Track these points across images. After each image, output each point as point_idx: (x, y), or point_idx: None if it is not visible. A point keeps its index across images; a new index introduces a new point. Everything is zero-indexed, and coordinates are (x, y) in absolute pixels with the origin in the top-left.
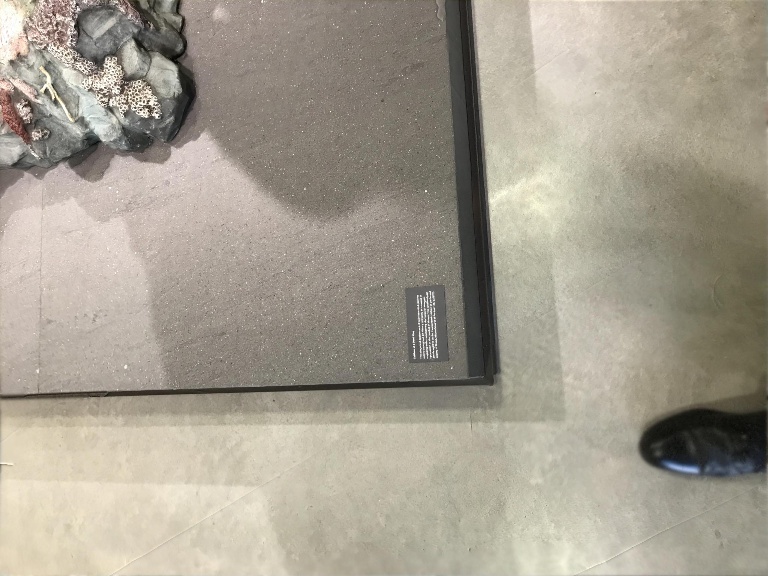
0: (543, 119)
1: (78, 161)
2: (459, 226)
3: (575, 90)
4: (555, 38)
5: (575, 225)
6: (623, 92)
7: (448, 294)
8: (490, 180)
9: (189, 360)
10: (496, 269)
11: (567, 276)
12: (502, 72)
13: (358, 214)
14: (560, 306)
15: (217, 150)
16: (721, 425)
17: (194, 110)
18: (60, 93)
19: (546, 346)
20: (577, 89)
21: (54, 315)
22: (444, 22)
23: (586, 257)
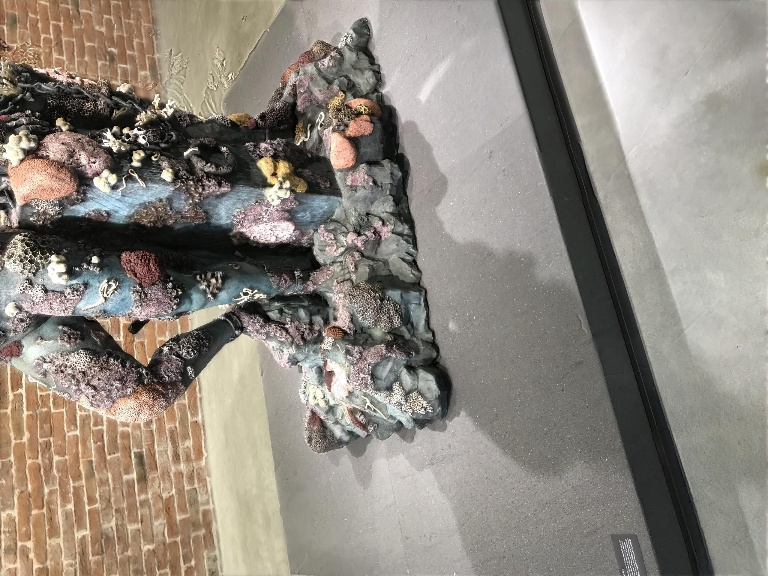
0: (700, 372)
1: (399, 429)
2: (636, 487)
3: (720, 345)
4: (693, 301)
5: (748, 463)
6: (760, 345)
7: (640, 541)
8: (671, 423)
9: (489, 574)
10: (694, 498)
11: (753, 508)
12: (659, 333)
13: (567, 475)
14: (753, 534)
15: (472, 424)
16: None
17: (453, 395)
18: (376, 406)
19: (751, 568)
20: (721, 344)
21: (408, 534)
22: (589, 329)
23: (763, 493)
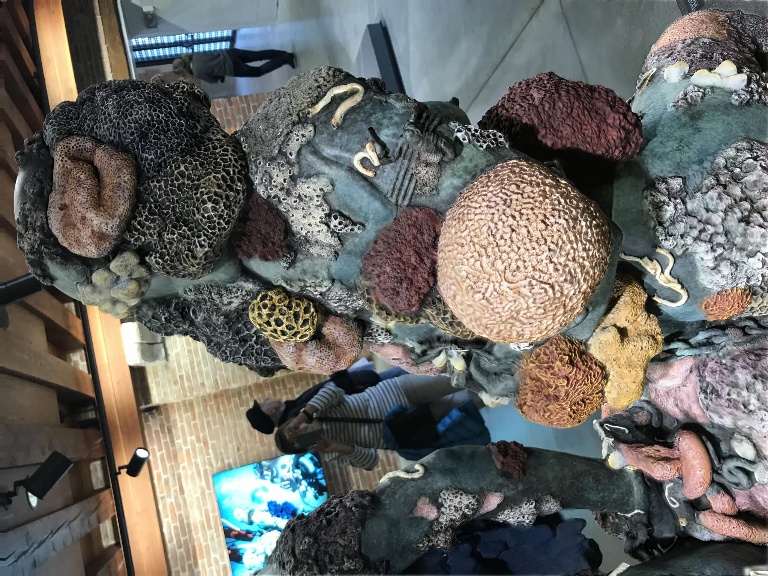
0: None
1: None
2: None
3: None
4: None
5: None
6: None
7: None
8: None
9: None
10: None
11: None
12: None
13: None
14: None
15: None
16: (636, 23)
17: None
18: None
19: None
20: None
21: None
22: None
23: None
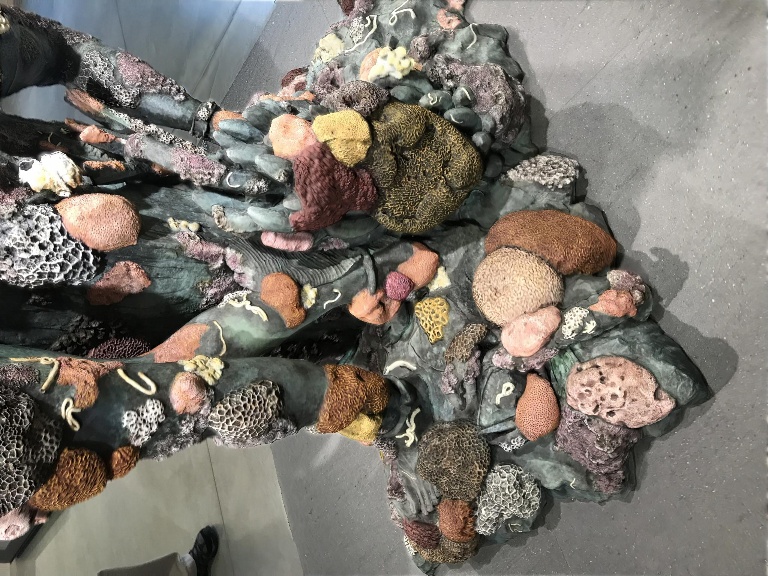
0: None
1: None
2: None
3: None
4: None
5: None
6: None
7: None
8: None
9: None
10: None
11: None
12: None
13: None
14: None
15: None
16: None
17: None
18: None
19: None
20: None
21: None
22: None
23: None
